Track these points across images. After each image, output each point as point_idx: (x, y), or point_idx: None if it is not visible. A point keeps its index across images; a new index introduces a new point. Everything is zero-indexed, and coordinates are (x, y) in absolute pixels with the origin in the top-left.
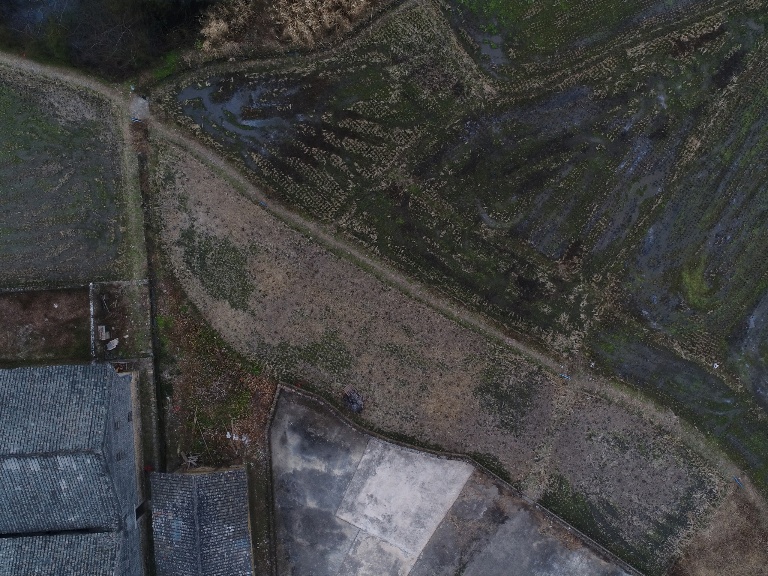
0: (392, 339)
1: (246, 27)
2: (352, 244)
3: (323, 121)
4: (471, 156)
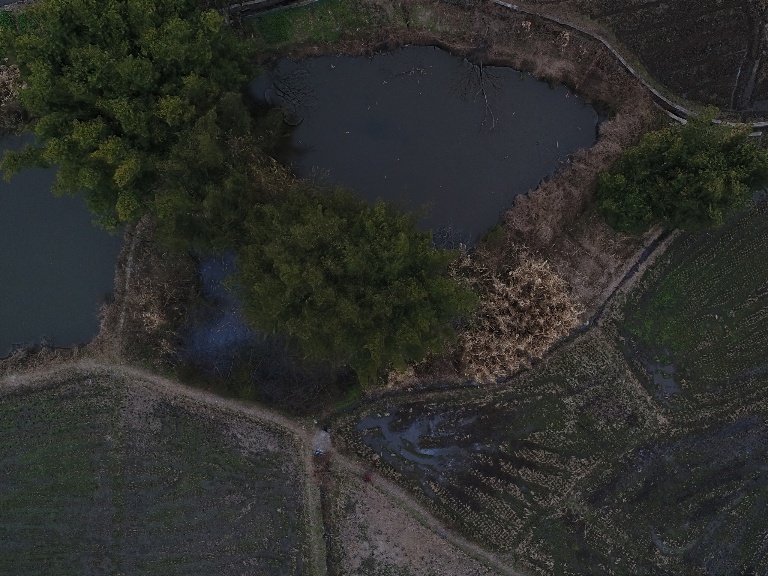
0: None
1: (428, 365)
2: (530, 574)
3: (500, 450)
4: (645, 484)
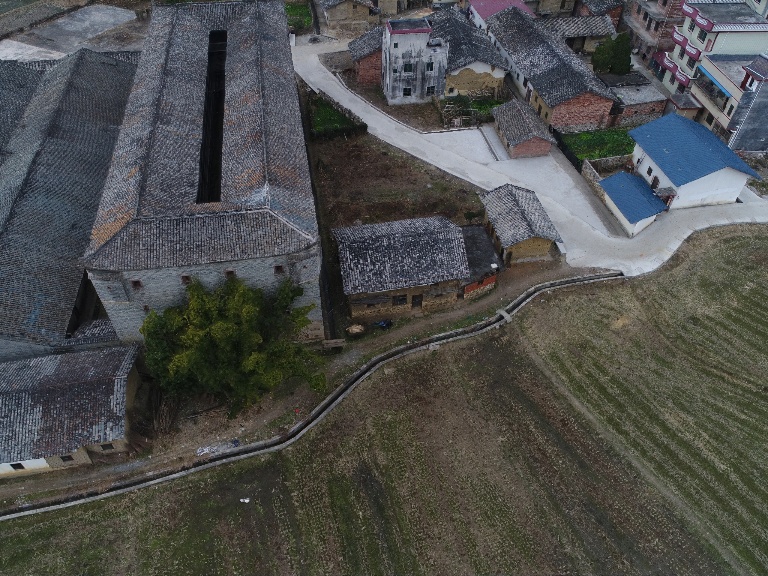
0: None
1: None
2: None
3: None
4: None
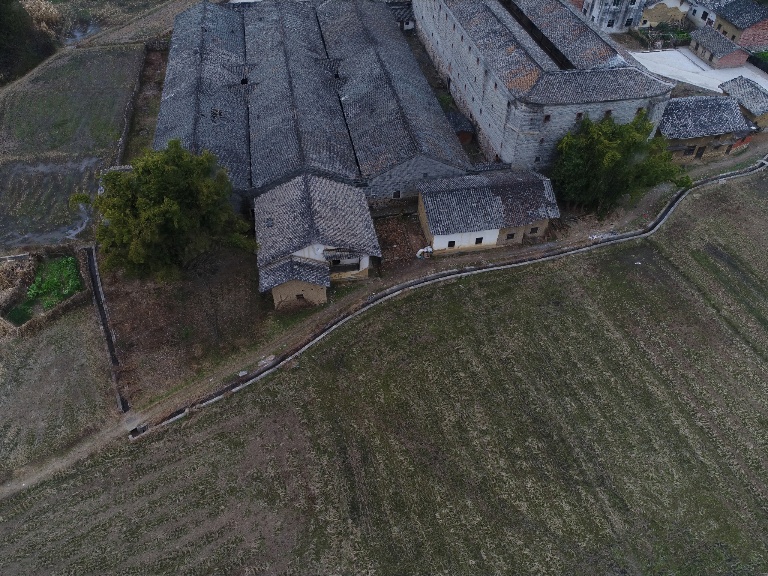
0: (187, 5)
1: None
2: None
3: None
4: None
